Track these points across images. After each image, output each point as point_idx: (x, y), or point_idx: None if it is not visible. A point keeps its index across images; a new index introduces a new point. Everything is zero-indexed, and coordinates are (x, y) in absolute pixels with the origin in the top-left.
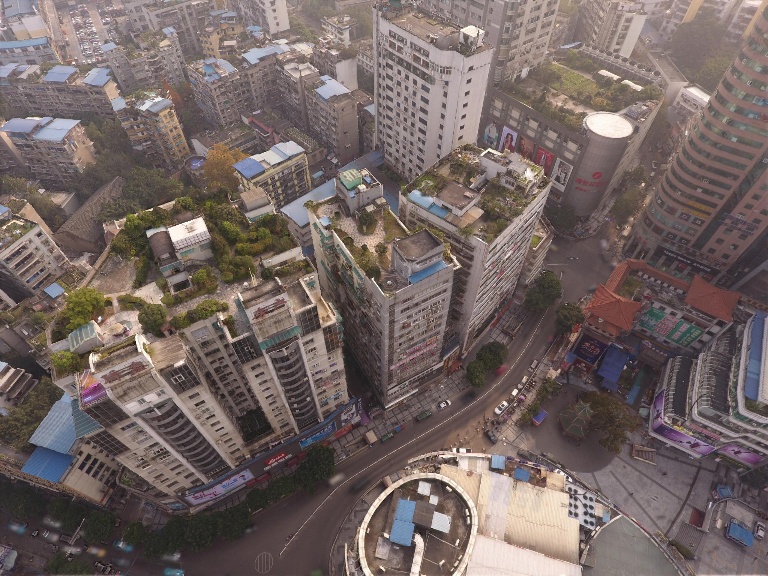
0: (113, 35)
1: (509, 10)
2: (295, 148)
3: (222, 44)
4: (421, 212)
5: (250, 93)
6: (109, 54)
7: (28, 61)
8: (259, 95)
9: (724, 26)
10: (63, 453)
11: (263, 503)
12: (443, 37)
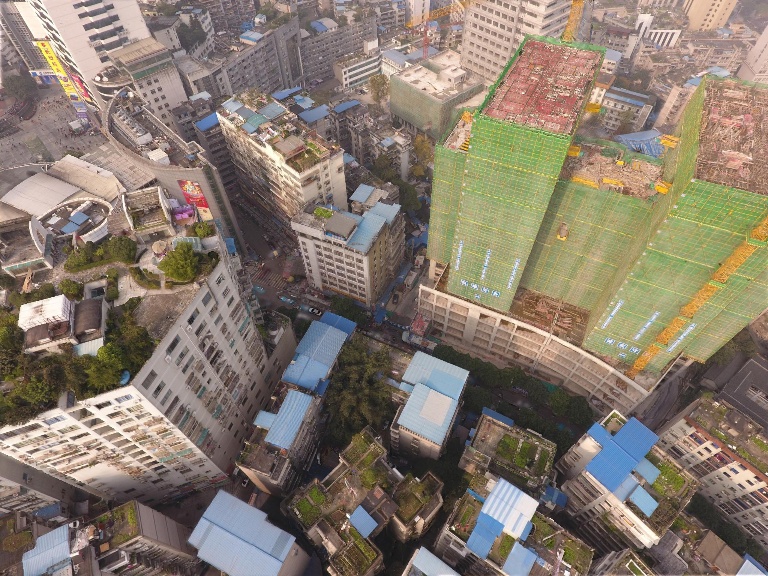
0: None
1: None
2: None
3: None
4: None
5: None
6: None
7: None
8: None
9: None
10: None
11: None
12: None
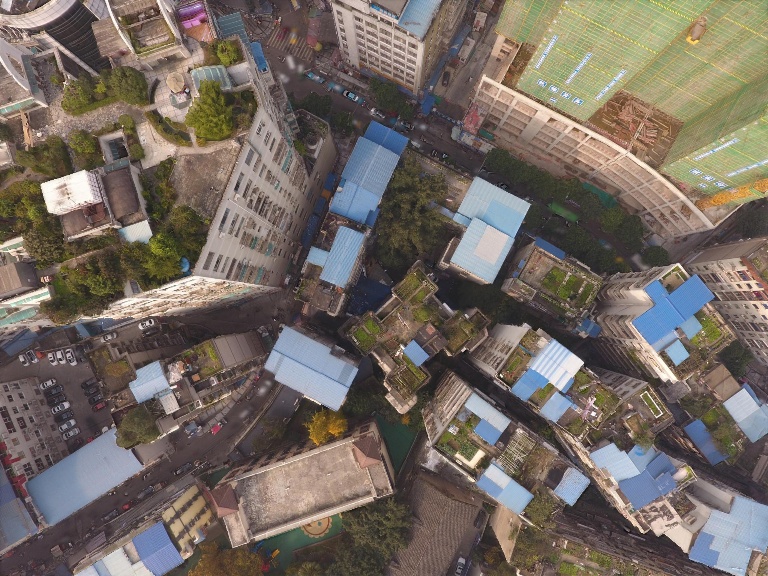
0: None
1: None
2: None
3: None
4: None
5: None
6: None
7: None
8: None
9: None
10: None
11: None
12: None
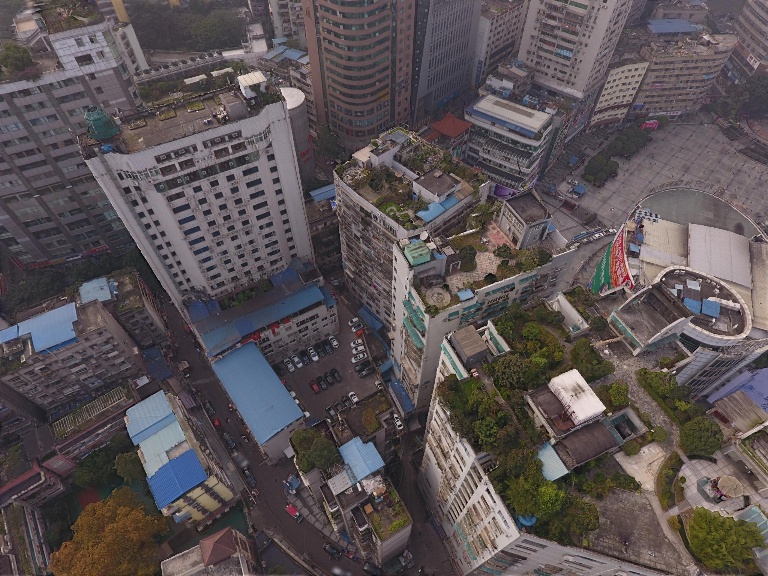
0: None
1: (123, 74)
2: (152, 404)
3: None
4: (437, 221)
5: None
6: None
7: None
8: None
9: (158, 3)
10: None
11: None
12: (240, 105)
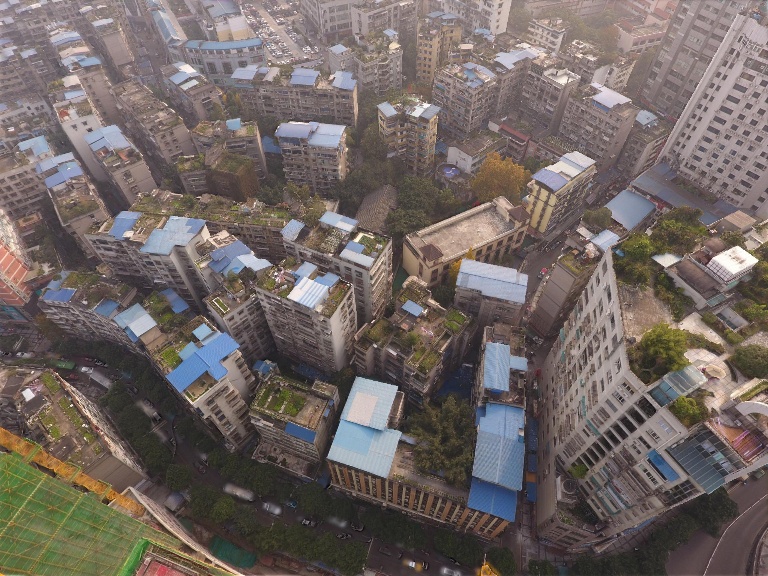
0: (298, 36)
1: None
2: (585, 159)
3: (455, 47)
4: None
5: (494, 99)
6: (339, 57)
7: (240, 62)
8: (502, 101)
9: None
10: (507, 489)
11: (675, 545)
12: None
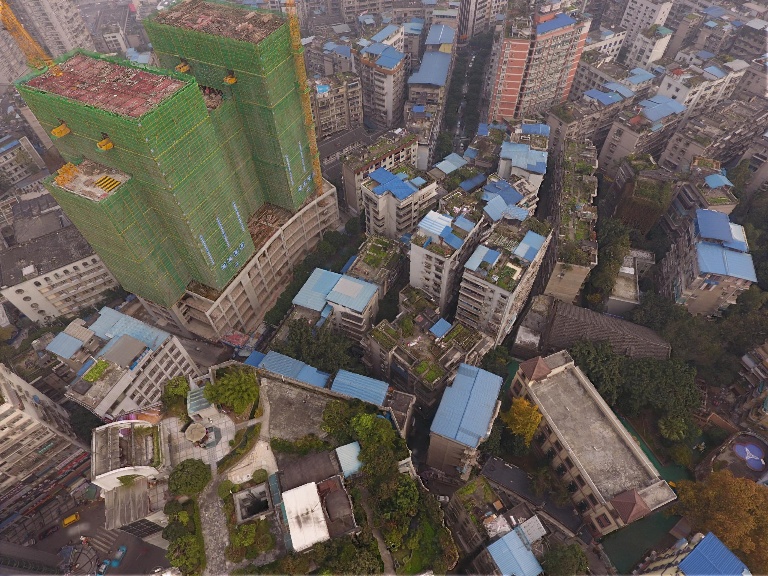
0: None
1: None
2: None
3: None
4: None
5: None
6: None
7: None
8: None
9: None
10: None
11: None
12: None
